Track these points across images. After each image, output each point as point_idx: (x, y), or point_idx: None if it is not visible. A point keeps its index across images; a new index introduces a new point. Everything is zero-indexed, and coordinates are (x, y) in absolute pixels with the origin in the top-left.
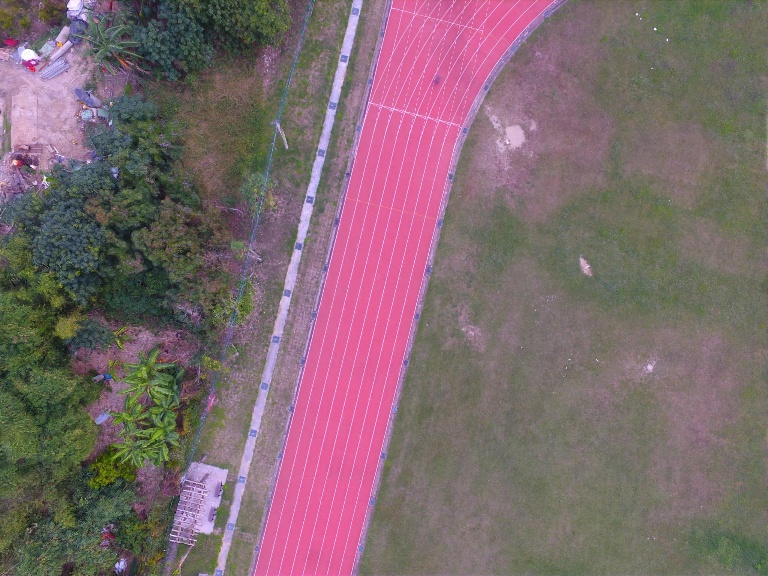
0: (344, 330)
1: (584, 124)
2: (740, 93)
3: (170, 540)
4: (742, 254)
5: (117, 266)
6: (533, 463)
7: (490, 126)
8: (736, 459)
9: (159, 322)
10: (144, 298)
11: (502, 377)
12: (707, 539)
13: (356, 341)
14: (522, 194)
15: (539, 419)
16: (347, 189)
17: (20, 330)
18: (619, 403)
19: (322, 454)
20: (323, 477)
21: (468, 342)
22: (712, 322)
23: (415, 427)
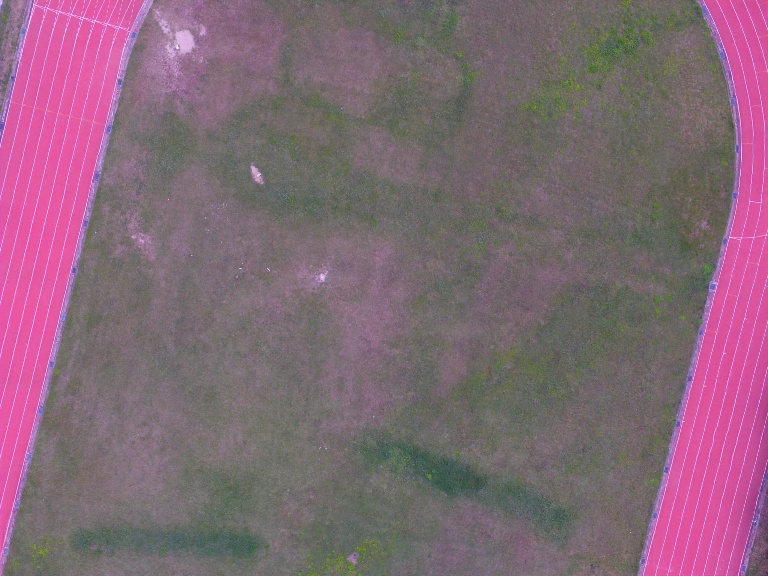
0: (10, 236)
1: (254, 30)
2: (413, 0)
3: None
4: (415, 163)
5: None
6: (203, 372)
7: (159, 31)
8: (408, 369)
9: None
10: None
11: (172, 285)
12: (379, 449)
13: (22, 248)
14: (192, 100)
15: (209, 328)
16: (11, 93)
17: None
18: (291, 312)
19: None
20: None
21: (138, 250)
22: (385, 232)
23: (83, 335)
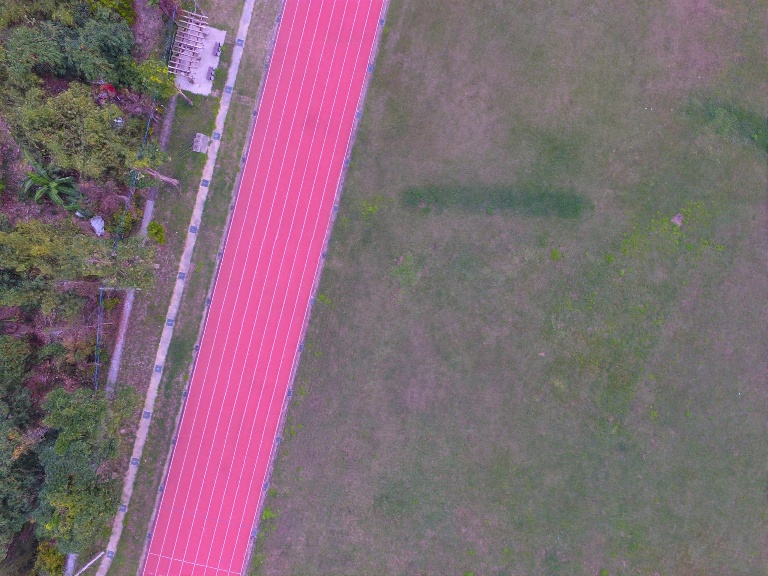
0: None
1: None
2: None
3: (168, 71)
4: None
5: None
6: (531, 31)
7: None
8: (735, 29)
9: None
10: None
11: None
12: (704, 110)
13: None
14: None
15: None
16: None
17: None
18: None
19: (320, 19)
20: (321, 42)
21: None
22: None
23: None
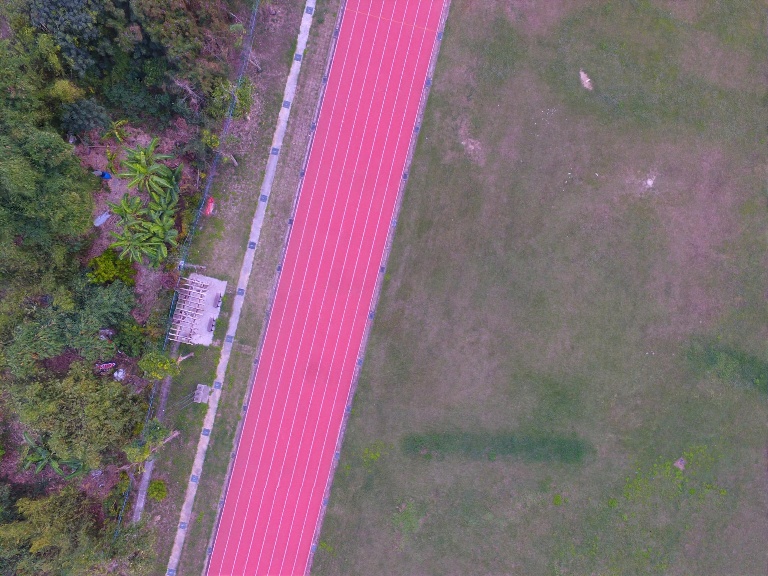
0: (343, 142)
1: None
2: None
3: (169, 338)
4: (743, 68)
5: (115, 38)
6: (532, 277)
7: None
8: (735, 274)
9: (158, 124)
10: (143, 93)
11: (502, 191)
12: (706, 354)
13: (355, 154)
14: (522, 6)
15: (538, 233)
16: None
17: (18, 81)
18: (619, 218)
19: (321, 267)
20: (322, 290)
21: (468, 156)
22: (712, 137)
23: (414, 240)
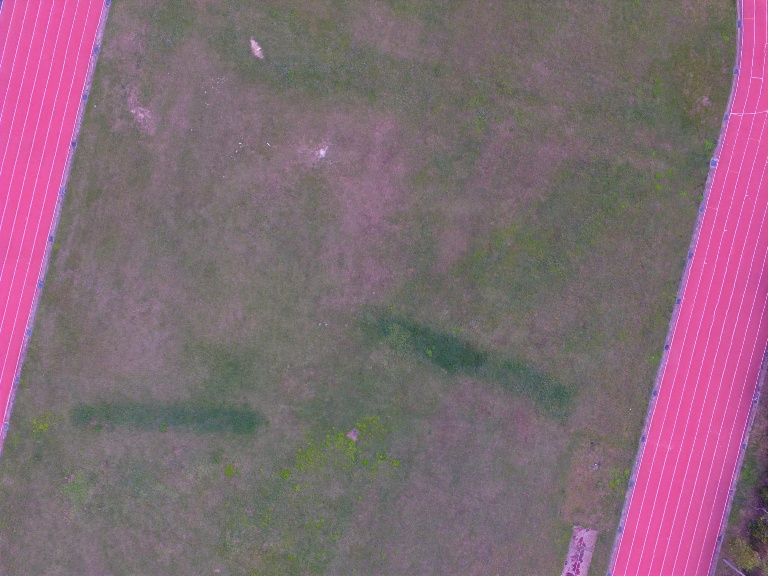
0: (9, 110)
1: None
2: None
3: None
4: (415, 38)
5: None
6: (203, 247)
7: None
8: (408, 245)
9: None
10: None
11: (172, 160)
12: (379, 325)
13: (22, 121)
14: None
15: (209, 203)
16: None
17: None
18: (291, 188)
19: None
20: None
21: (137, 124)
22: (385, 107)
23: (83, 210)
